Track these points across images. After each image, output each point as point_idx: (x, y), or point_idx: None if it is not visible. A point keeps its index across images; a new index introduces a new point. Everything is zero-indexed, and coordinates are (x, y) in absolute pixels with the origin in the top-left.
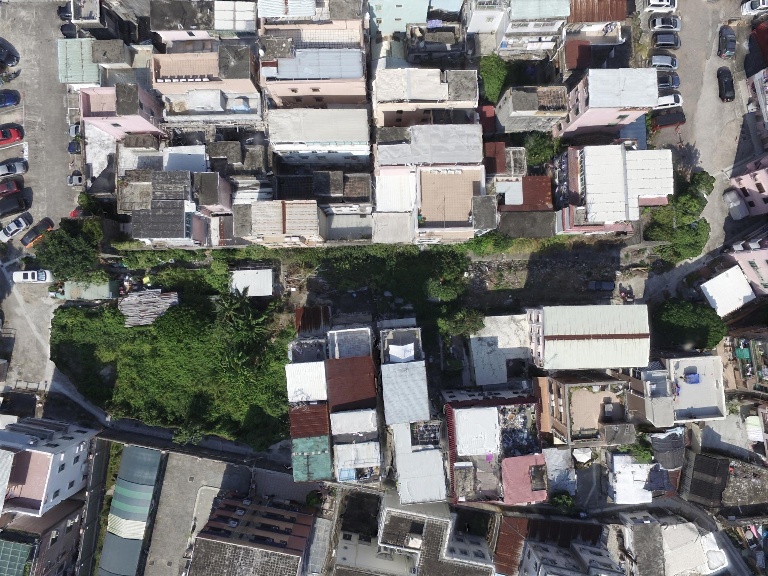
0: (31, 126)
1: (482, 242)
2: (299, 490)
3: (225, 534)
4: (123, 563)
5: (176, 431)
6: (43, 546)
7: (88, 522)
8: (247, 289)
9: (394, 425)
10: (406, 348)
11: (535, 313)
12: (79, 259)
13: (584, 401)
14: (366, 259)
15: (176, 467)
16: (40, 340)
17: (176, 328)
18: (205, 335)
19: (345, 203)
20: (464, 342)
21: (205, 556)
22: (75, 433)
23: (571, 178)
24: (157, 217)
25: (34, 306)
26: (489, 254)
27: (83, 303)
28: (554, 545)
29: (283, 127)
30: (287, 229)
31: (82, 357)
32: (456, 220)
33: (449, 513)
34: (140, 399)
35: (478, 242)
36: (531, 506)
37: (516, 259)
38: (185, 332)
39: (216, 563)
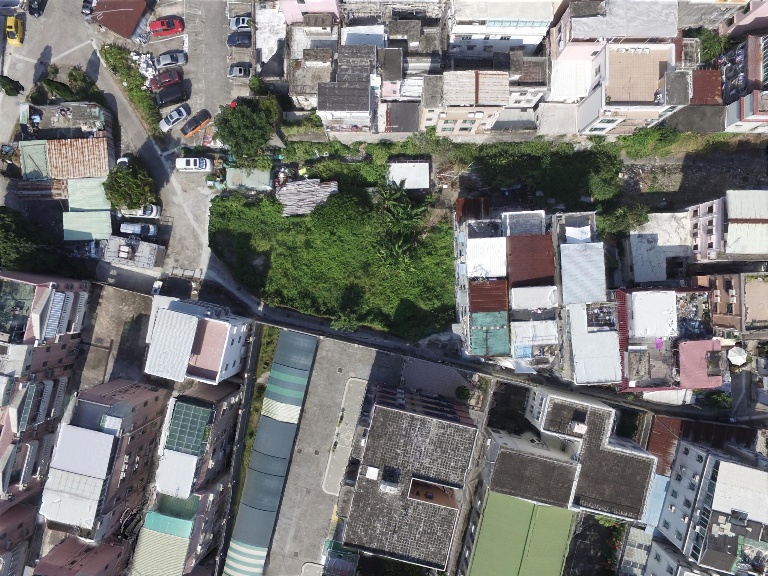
0: (191, 19)
1: (648, 136)
2: (446, 385)
3: (401, 406)
4: (278, 445)
5: (336, 316)
6: (217, 414)
7: (244, 404)
8: (404, 181)
9: (570, 305)
10: (583, 230)
11: (704, 206)
12: (258, 135)
13: (757, 293)
14: (520, 157)
15: (325, 358)
16: (196, 229)
17: (340, 213)
18: (363, 225)
19: (521, 86)
20: (618, 242)
21: (383, 425)
22: (234, 316)
23: (751, 66)
24: (343, 90)
25: (191, 195)
26: (642, 157)
27: None
28: (708, 446)
29: (468, 4)
30: (479, 99)
31: (238, 245)
32: (641, 100)
33: None
34: (294, 288)
35: (647, 134)
36: (678, 410)
37: (669, 163)
38: (348, 218)
39: (393, 432)
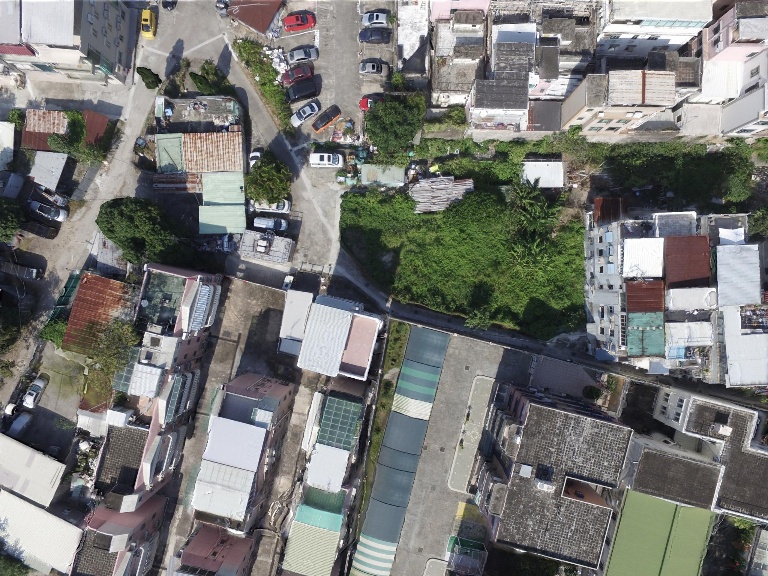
0: (323, 14)
1: None
2: (573, 385)
3: (553, 405)
4: (410, 441)
5: (472, 314)
6: None
7: None
8: (538, 180)
9: (724, 307)
10: (737, 232)
11: None
12: (409, 131)
13: None
14: (653, 157)
15: (453, 355)
16: (326, 224)
17: (479, 211)
18: None
19: None
20: None
21: (537, 423)
22: (368, 312)
23: None
24: (501, 88)
25: (321, 191)
26: None
27: (368, 190)
28: None
29: (628, 3)
30: (646, 99)
31: (369, 242)
32: None
33: (747, 408)
34: (424, 285)
35: None
36: None
37: None
38: (487, 216)
39: (547, 431)
